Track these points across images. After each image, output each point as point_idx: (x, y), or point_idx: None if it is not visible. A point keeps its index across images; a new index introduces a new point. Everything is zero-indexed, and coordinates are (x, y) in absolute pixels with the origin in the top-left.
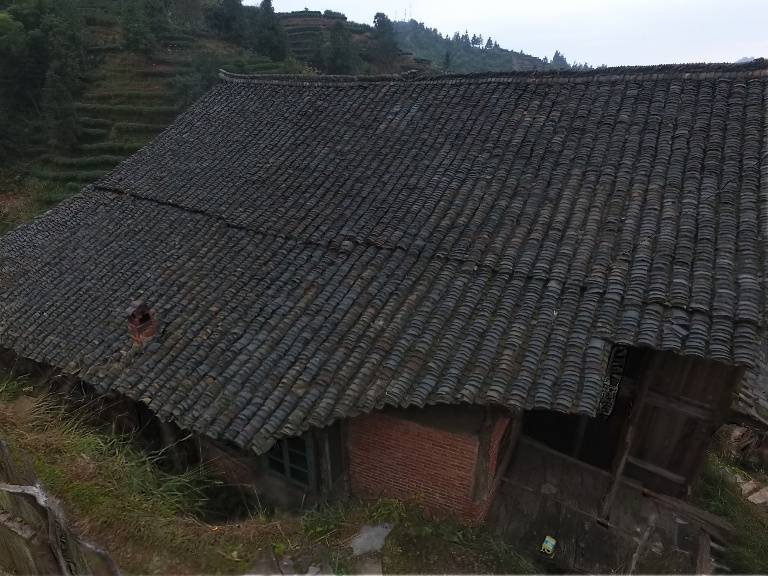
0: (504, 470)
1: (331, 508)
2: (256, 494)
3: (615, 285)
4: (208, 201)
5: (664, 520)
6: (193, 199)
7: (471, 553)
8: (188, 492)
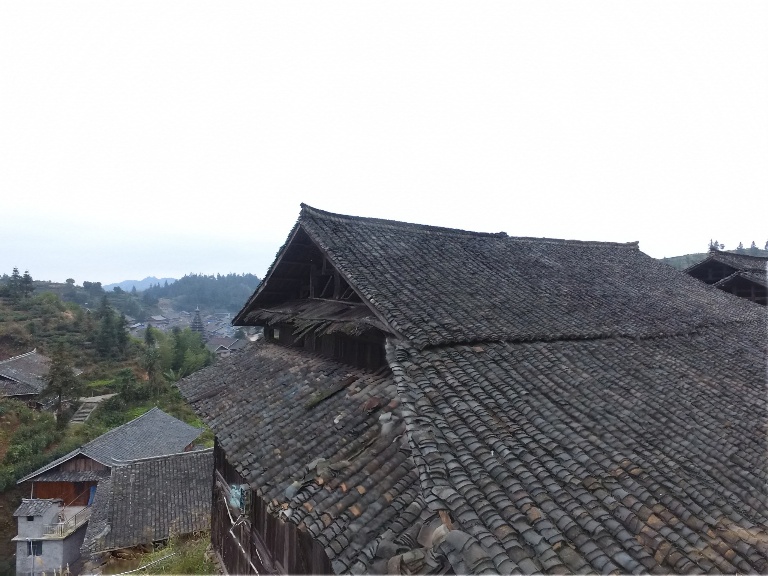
0: None
1: None
2: None
3: (761, 317)
4: (584, 327)
5: None
6: (571, 328)
7: None
8: None
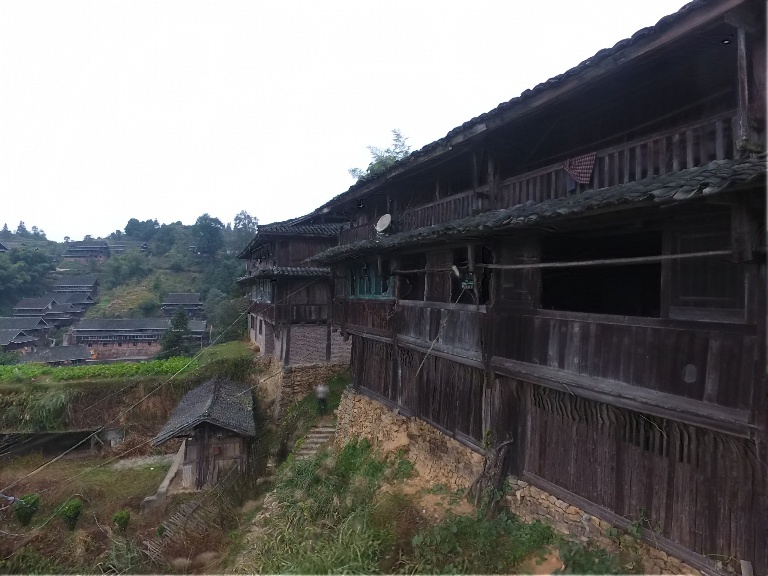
0: None
1: None
2: None
3: None
4: None
5: None
6: None
7: None
8: None
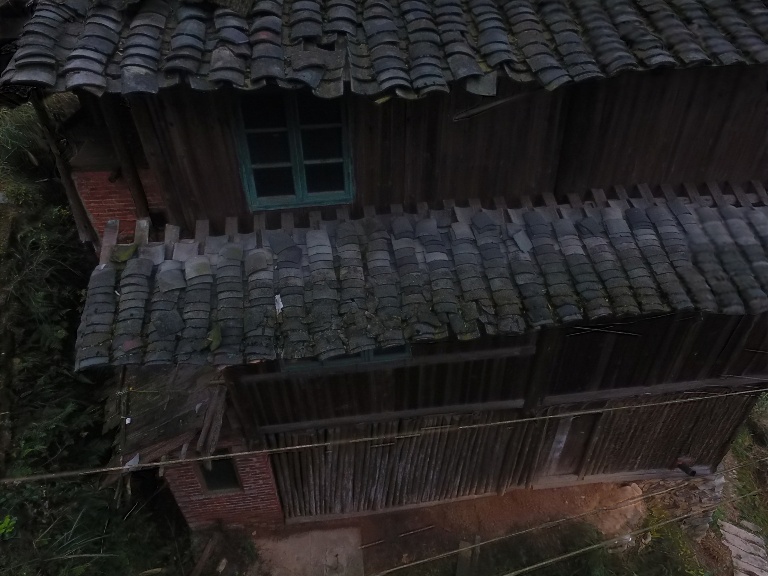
0: None
1: (21, 181)
2: (11, 153)
3: None
4: None
5: (197, 396)
6: None
7: (2, 243)
8: (4, 138)
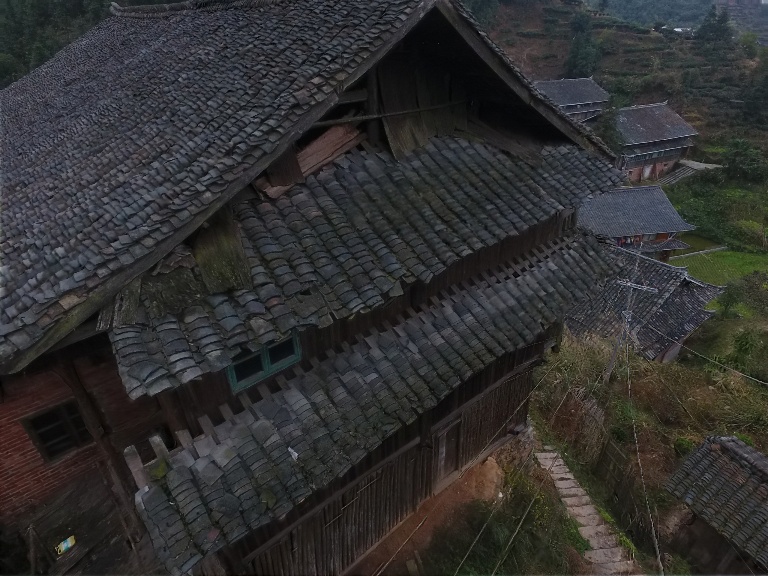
0: (107, 455)
1: None
2: None
3: None
4: None
5: None
6: None
7: None
8: None
